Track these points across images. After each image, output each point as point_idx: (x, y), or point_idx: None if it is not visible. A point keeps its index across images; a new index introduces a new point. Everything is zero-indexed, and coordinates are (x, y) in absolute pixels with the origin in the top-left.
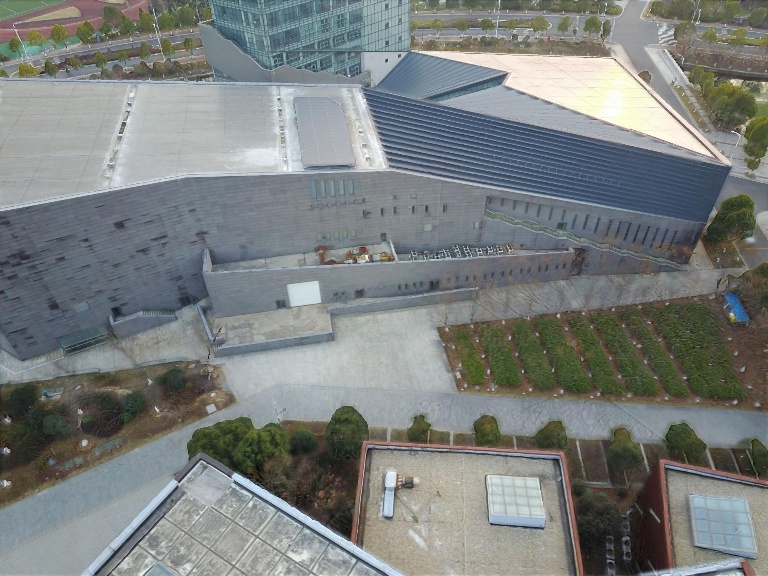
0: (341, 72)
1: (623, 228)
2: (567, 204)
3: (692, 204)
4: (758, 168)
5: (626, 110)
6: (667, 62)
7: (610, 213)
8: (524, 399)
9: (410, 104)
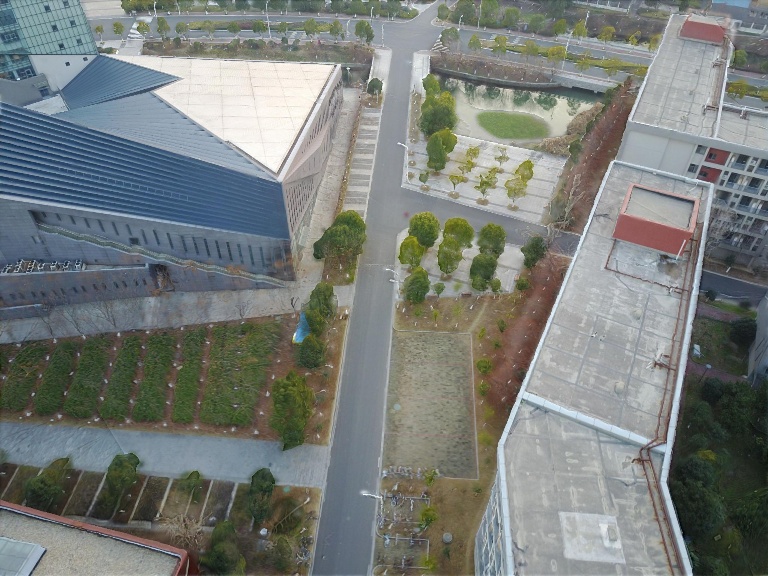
0: (5, 75)
1: (200, 244)
2: (122, 219)
3: (266, 220)
4: (438, 180)
5: (255, 120)
6: (424, 69)
7: (176, 229)
8: (17, 424)
9: (6, 111)
